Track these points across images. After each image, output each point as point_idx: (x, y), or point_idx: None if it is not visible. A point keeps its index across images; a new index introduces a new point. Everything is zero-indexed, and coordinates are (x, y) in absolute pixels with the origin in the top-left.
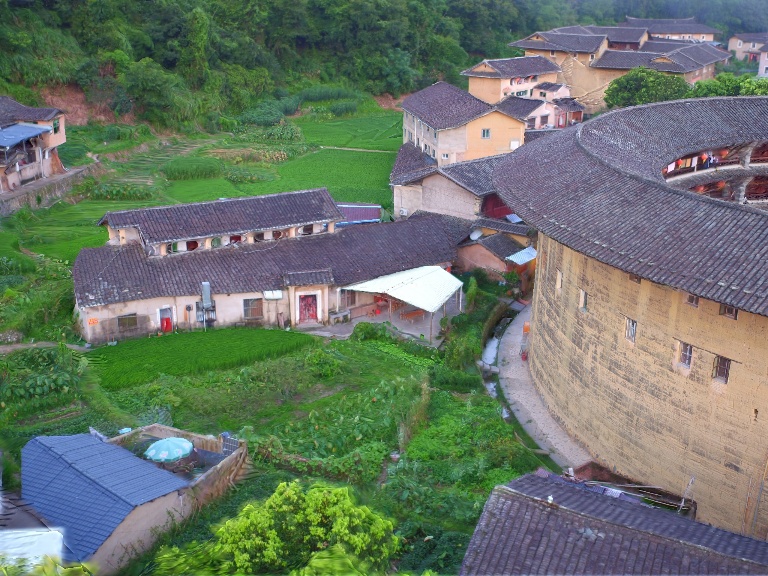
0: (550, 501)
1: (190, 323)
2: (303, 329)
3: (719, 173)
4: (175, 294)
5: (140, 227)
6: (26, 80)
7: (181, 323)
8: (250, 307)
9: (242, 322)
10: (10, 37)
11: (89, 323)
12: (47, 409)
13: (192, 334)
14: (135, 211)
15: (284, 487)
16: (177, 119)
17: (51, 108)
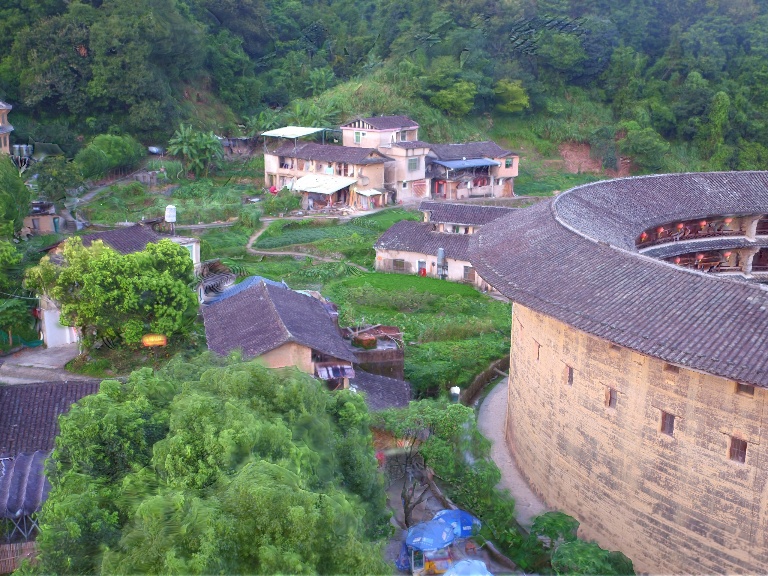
0: (265, 285)
1: (433, 274)
2: (494, 294)
3: None
4: (426, 253)
5: (433, 212)
6: (551, 137)
7: (429, 273)
8: (468, 272)
9: (462, 281)
10: (549, 106)
11: (378, 259)
12: (306, 283)
13: (423, 277)
14: (439, 203)
15: (166, 239)
16: None
17: None
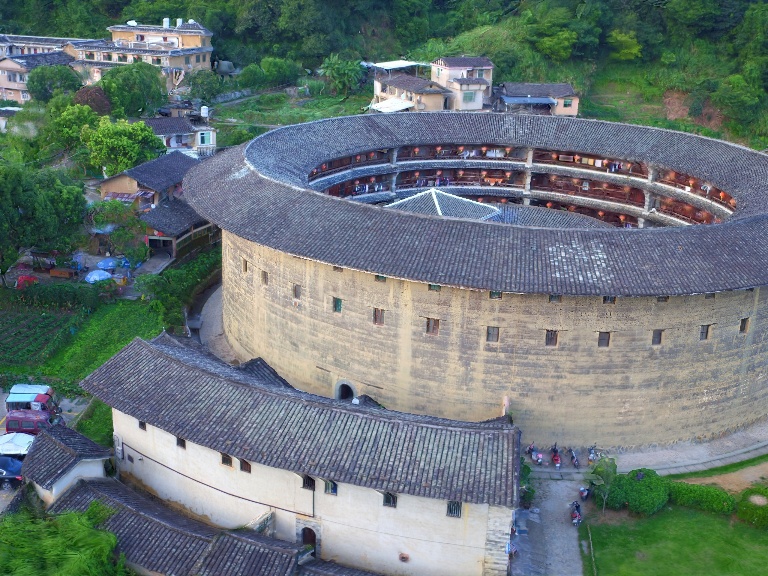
0: (171, 152)
1: None
2: None
3: (624, 179)
4: None
5: None
6: (659, 85)
7: None
8: None
9: None
10: (663, 56)
11: None
12: None
13: None
14: None
15: (142, 121)
16: (755, 133)
17: (568, 92)
